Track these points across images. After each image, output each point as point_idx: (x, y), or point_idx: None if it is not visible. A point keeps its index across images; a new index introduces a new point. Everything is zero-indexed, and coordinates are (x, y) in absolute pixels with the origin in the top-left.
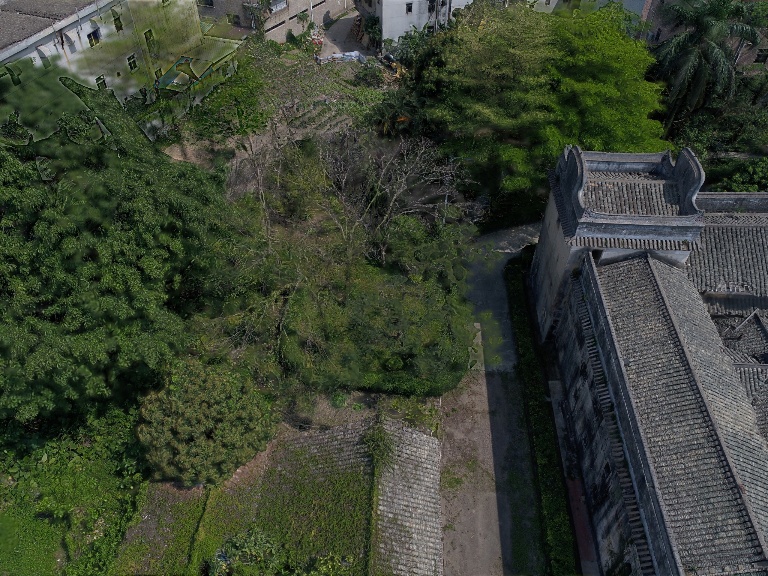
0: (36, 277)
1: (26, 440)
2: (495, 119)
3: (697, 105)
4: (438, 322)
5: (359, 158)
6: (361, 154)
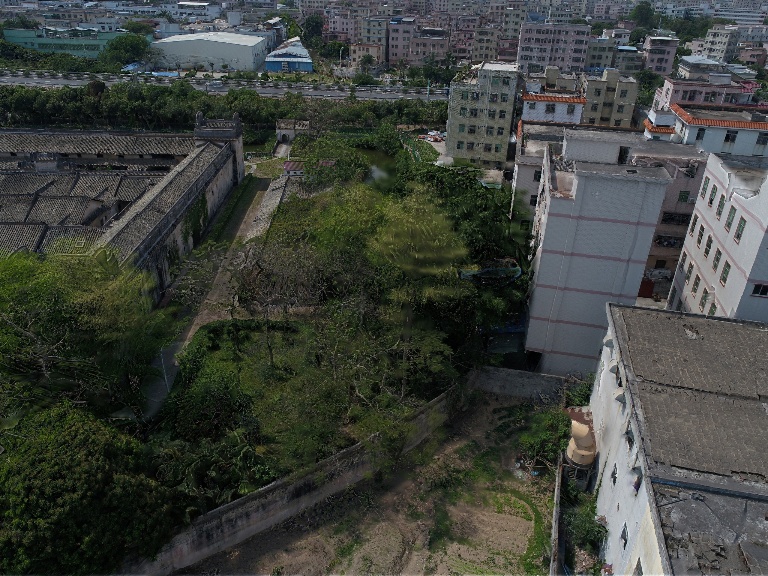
0: (396, 204)
1: None
2: None
3: None
4: None
5: None
6: None
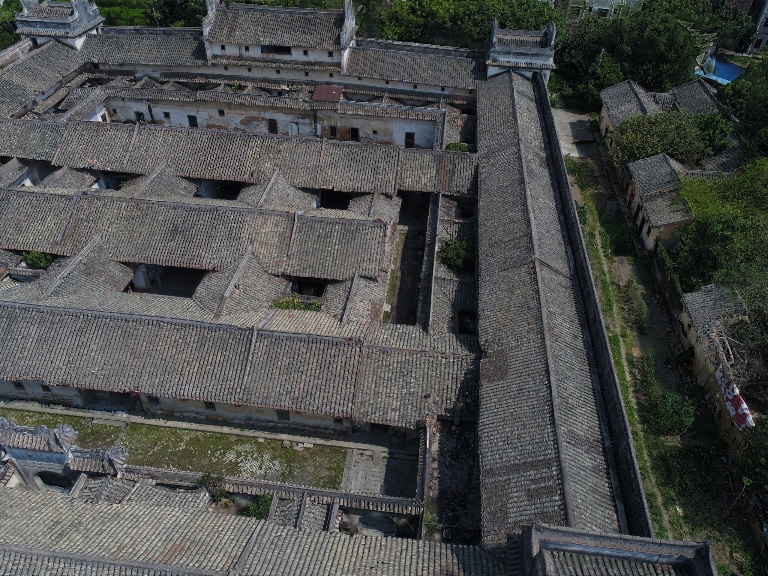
0: None
1: None
2: None
3: None
4: None
5: (4, 28)
6: (4, 26)
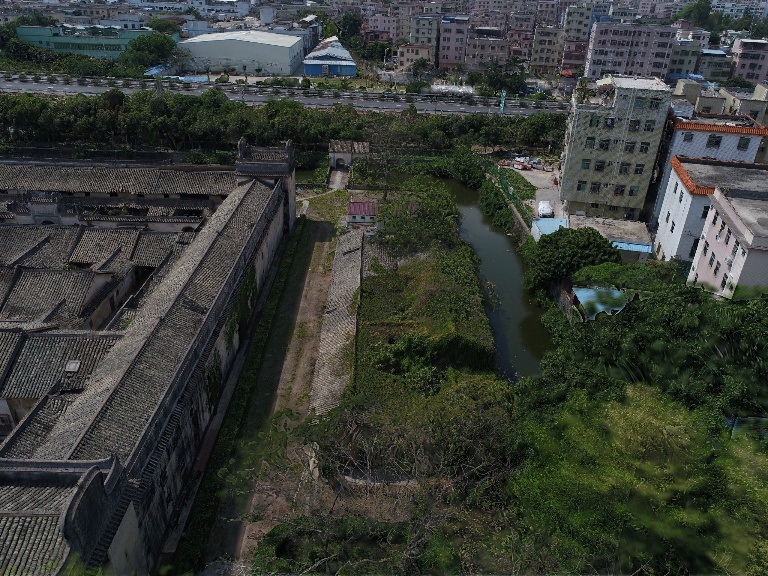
0: None
1: None
2: None
3: None
4: None
5: None
6: None
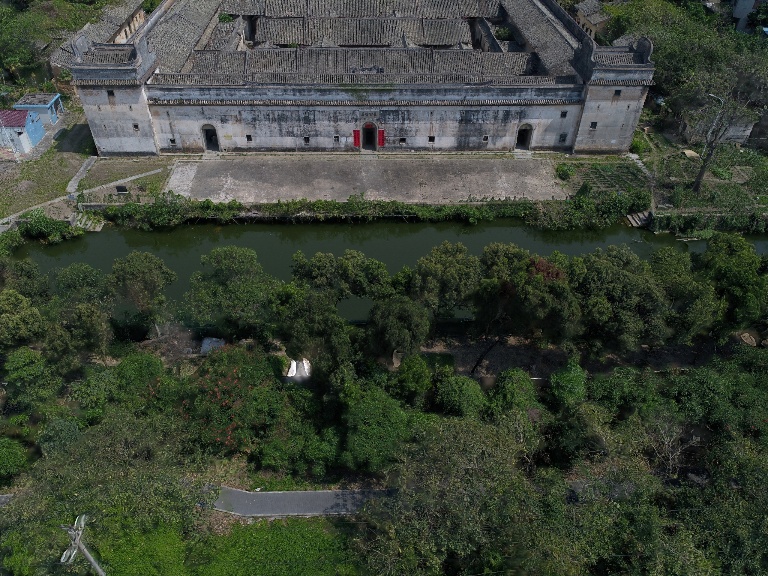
0: None
1: (20, 13)
2: None
3: None
4: None
5: None
6: None
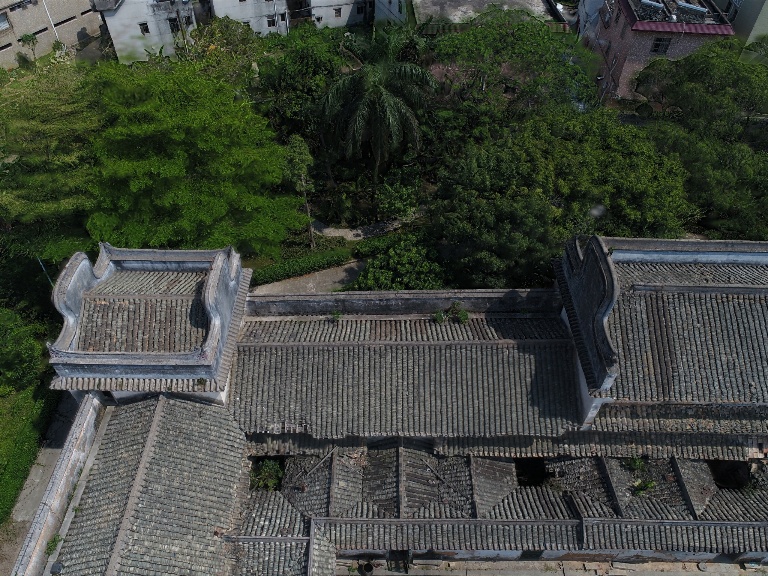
0: None
1: None
2: (15, 210)
3: (383, 158)
4: (6, 451)
5: None
6: None
